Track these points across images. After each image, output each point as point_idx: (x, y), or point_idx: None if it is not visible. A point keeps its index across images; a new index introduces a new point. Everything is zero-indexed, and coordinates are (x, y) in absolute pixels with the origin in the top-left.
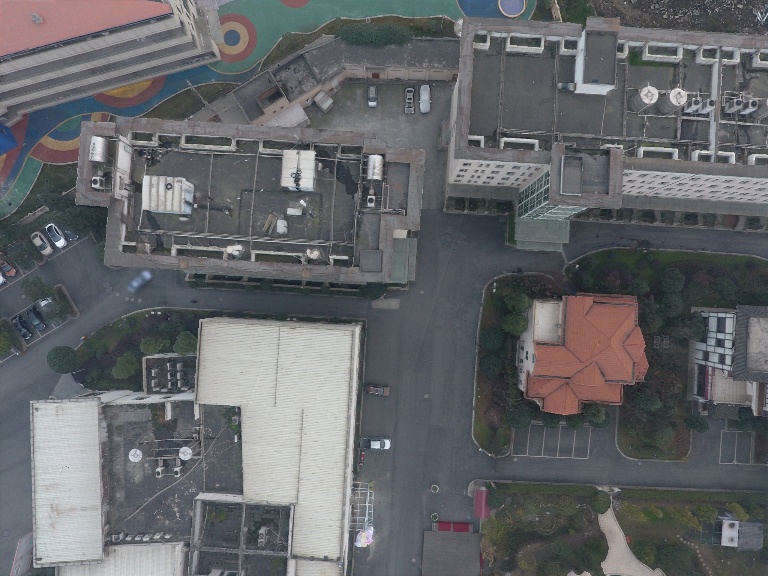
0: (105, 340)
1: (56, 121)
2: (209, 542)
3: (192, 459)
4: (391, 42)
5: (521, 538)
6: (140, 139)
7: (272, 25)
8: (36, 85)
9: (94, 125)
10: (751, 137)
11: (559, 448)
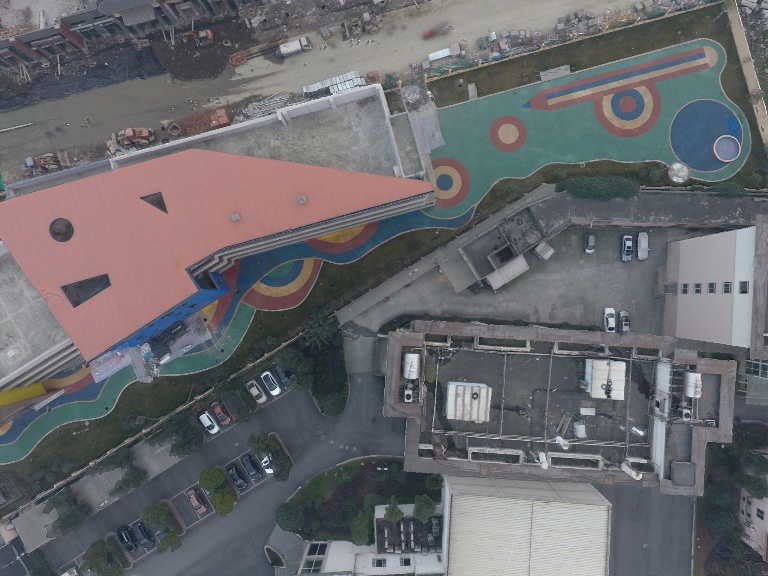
0: (320, 489)
1: (268, 266)
2: None
3: None
4: (618, 196)
5: None
6: (431, 338)
7: (485, 169)
8: None
9: (402, 336)
10: None
11: None
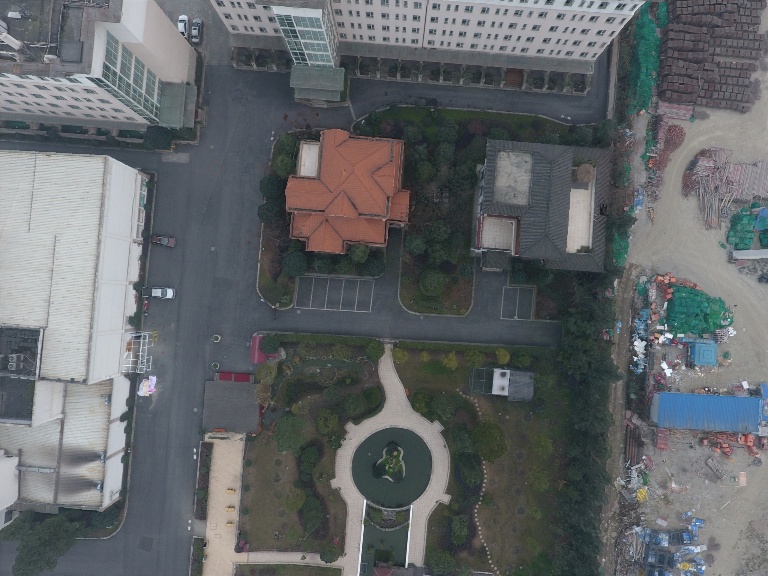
0: None
1: None
2: None
3: None
4: None
5: (300, 388)
6: None
7: None
8: None
9: None
10: None
11: (342, 301)
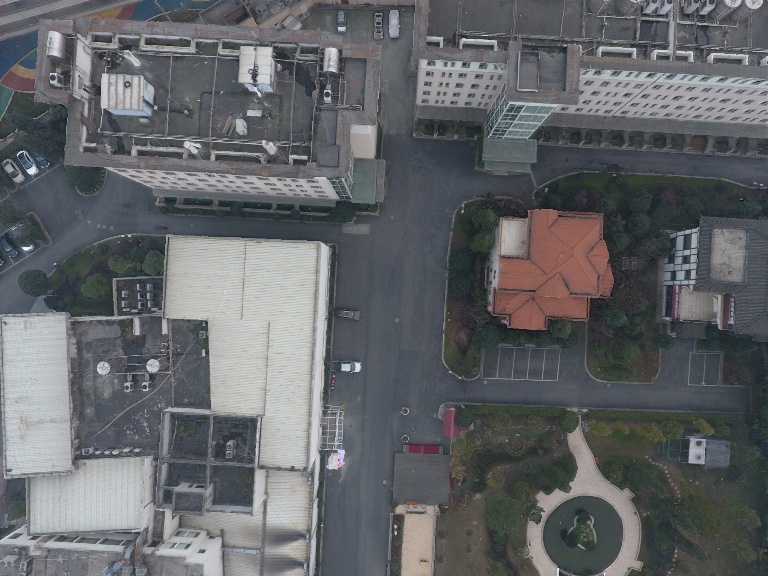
0: (77, 267)
1: (26, 49)
2: (178, 456)
3: (161, 375)
4: None
5: (491, 459)
6: (100, 42)
7: None
8: (4, 7)
9: (52, 23)
10: (710, 38)
11: (529, 371)
